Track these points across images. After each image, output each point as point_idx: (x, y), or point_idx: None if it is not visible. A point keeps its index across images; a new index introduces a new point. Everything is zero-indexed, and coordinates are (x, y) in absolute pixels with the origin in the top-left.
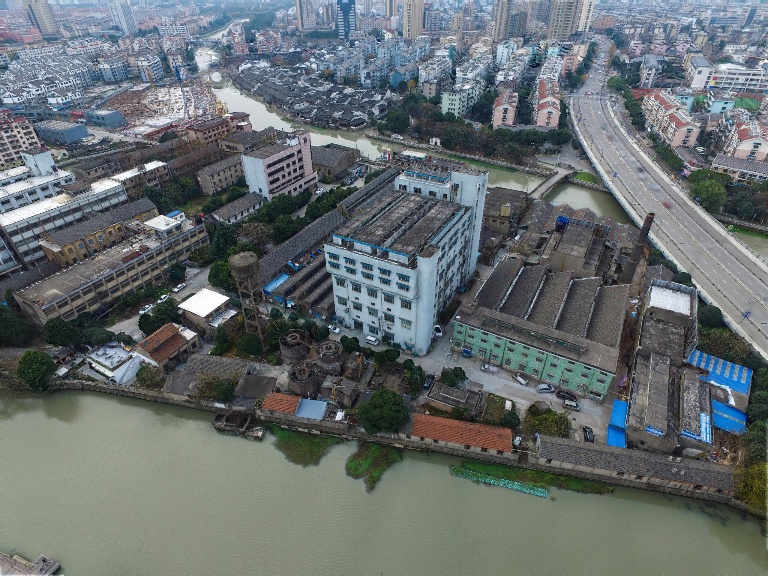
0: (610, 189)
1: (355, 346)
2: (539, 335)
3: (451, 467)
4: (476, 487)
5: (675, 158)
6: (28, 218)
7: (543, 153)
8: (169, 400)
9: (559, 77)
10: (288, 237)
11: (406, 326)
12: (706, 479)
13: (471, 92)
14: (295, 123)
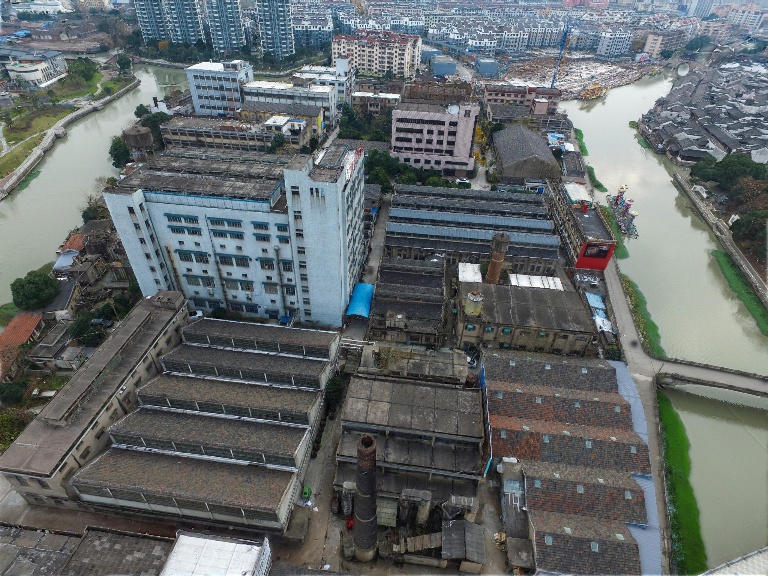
0: None
1: None
2: None
3: None
4: None
5: None
6: (258, 87)
7: None
8: None
9: None
10: None
11: None
12: None
13: None
14: (638, 131)
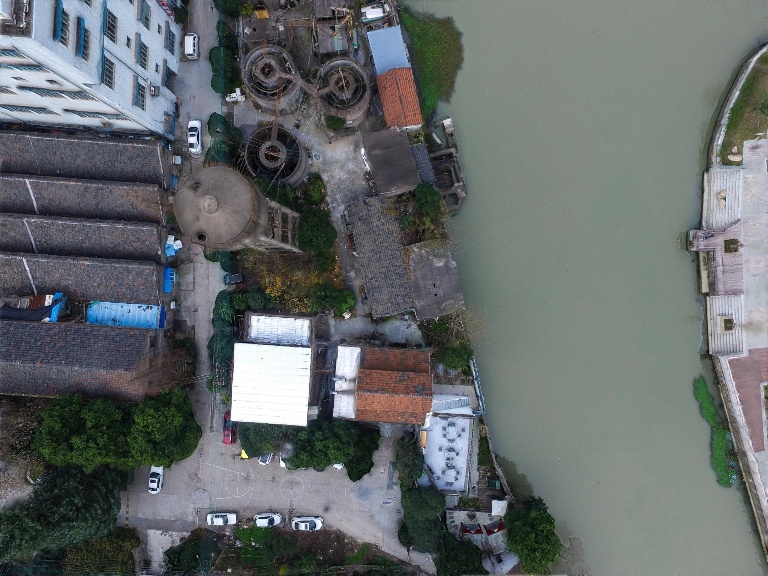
0: None
1: None
2: None
3: None
4: None
5: None
6: None
7: None
8: None
9: None
10: None
11: None
12: None
13: None
14: None
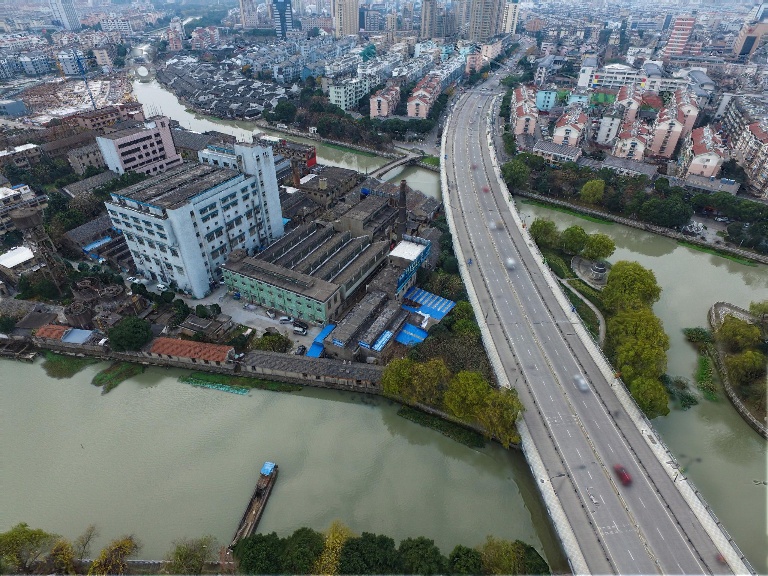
0: None
1: (140, 291)
2: (279, 275)
3: (180, 377)
4: (193, 389)
5: (512, 144)
6: None
7: (407, 140)
8: None
9: (458, 74)
10: None
11: (181, 273)
12: (364, 375)
13: (359, 86)
14: (198, 114)
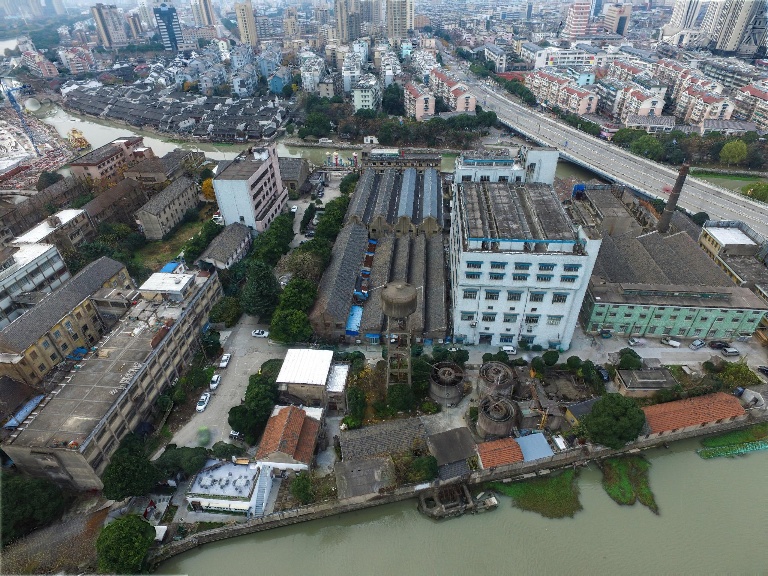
0: (568, 157)
1: (507, 361)
2: (684, 294)
3: (697, 451)
4: (735, 461)
5: (590, 124)
6: None
7: None
8: (346, 507)
9: None
10: (326, 264)
11: (553, 322)
12: None
13: (376, 87)
14: (188, 143)
